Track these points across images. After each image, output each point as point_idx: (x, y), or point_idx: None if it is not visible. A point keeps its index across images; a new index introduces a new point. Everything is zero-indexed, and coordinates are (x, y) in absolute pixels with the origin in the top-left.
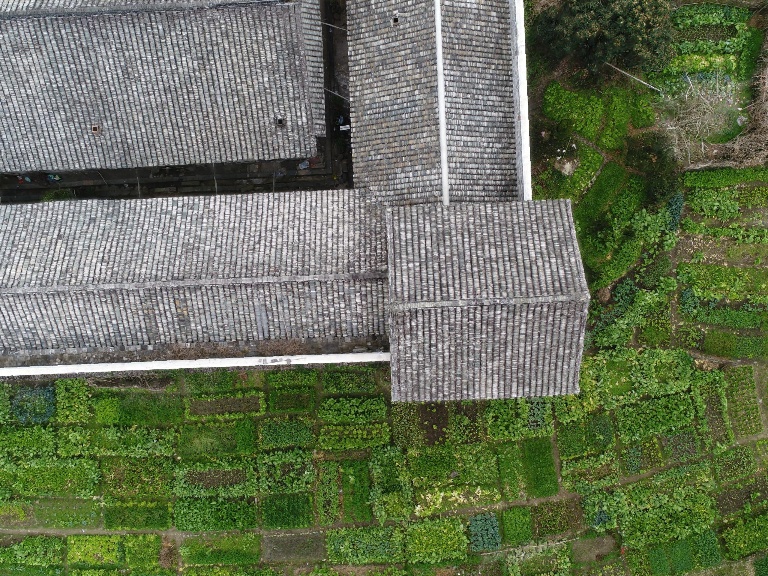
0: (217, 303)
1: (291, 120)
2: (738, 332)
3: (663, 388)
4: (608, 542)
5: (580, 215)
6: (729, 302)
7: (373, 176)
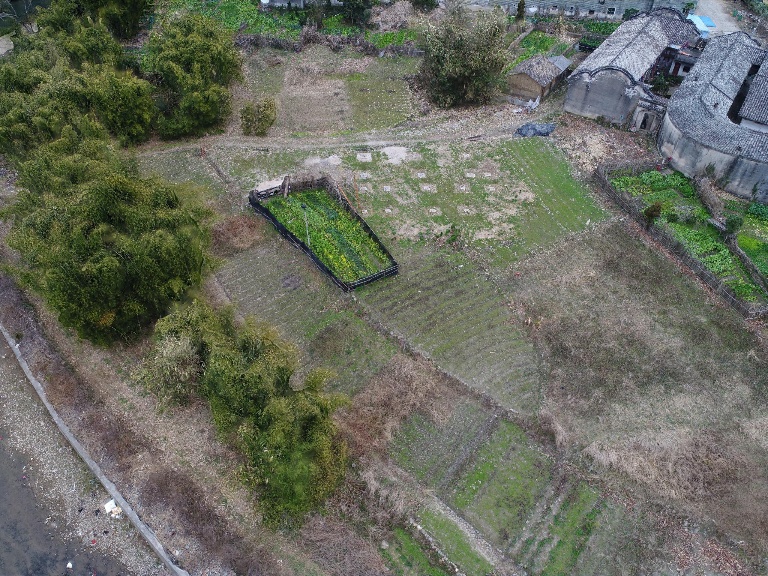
0: None
1: None
2: None
3: None
4: None
5: None
6: None
7: None
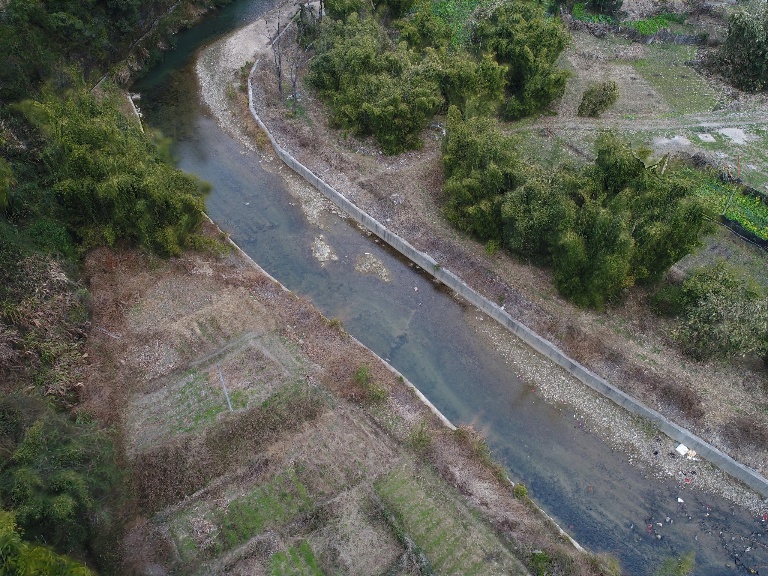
0: None
1: None
2: None
3: None
4: None
5: (544, 5)
6: None
7: None
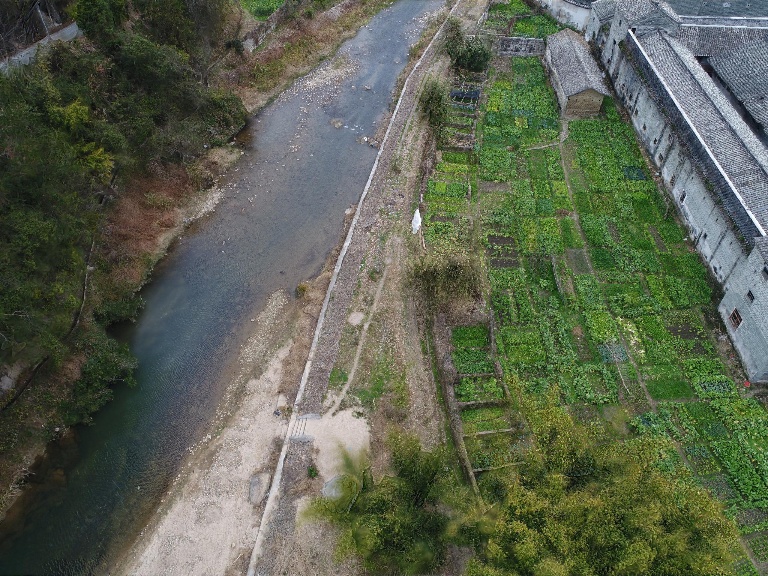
0: (762, 192)
1: None
2: None
3: (767, 474)
4: (624, 431)
5: None
6: None
7: None
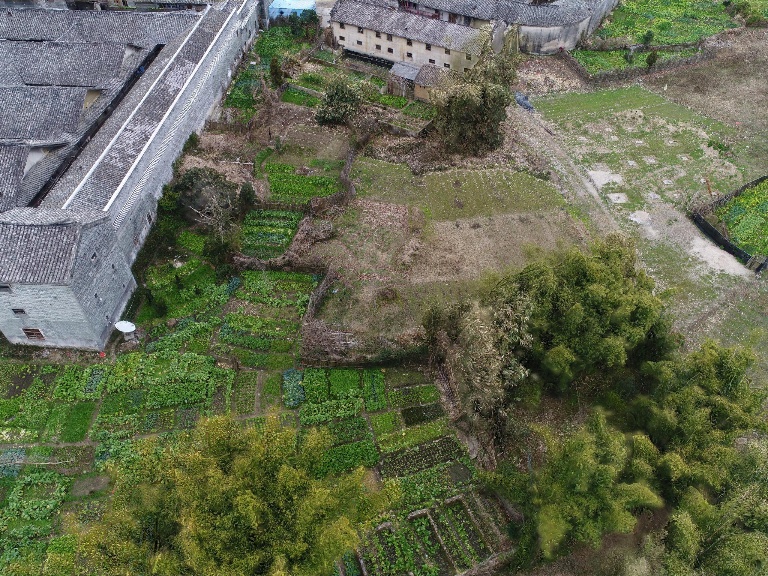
0: None
1: (6, 194)
2: (255, 352)
3: (188, 375)
4: (105, 482)
5: (176, 285)
6: (253, 335)
7: None
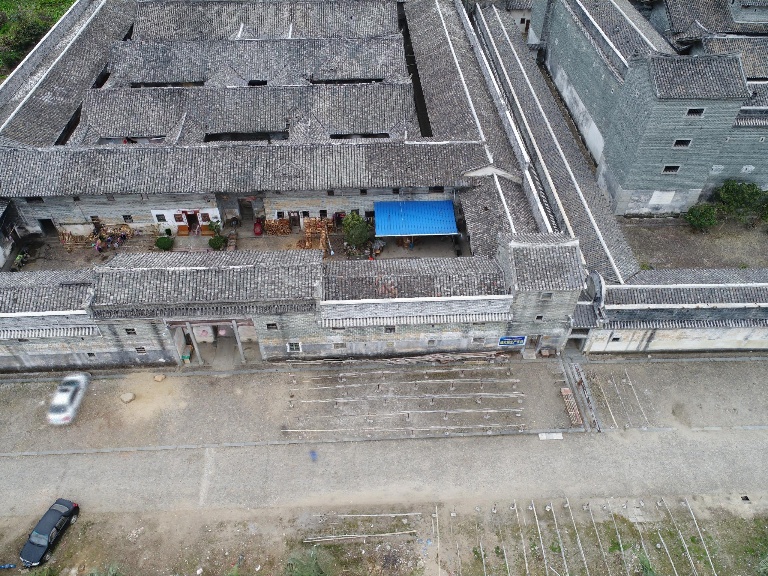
0: None
1: None
2: None
3: None
4: None
5: None
6: None
7: (135, 6)
